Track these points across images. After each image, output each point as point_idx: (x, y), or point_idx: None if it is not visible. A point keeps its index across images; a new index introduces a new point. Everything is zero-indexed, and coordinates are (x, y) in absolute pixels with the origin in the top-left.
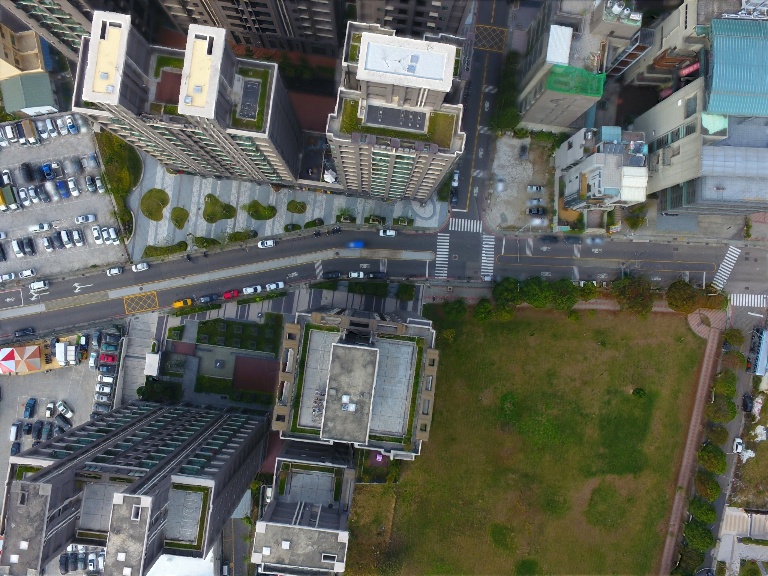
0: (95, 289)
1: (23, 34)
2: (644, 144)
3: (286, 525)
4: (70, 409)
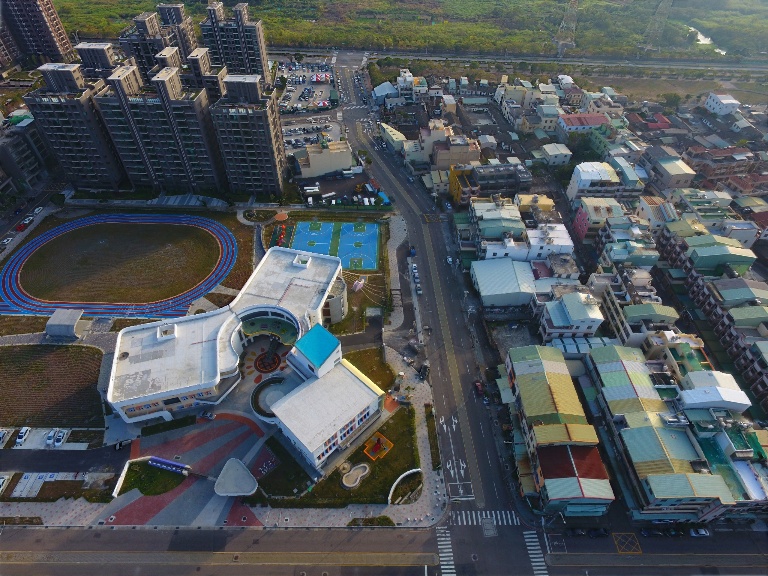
0: (287, 121)
1: (307, 168)
2: (4, 121)
3: (172, 6)
4: (299, 99)
